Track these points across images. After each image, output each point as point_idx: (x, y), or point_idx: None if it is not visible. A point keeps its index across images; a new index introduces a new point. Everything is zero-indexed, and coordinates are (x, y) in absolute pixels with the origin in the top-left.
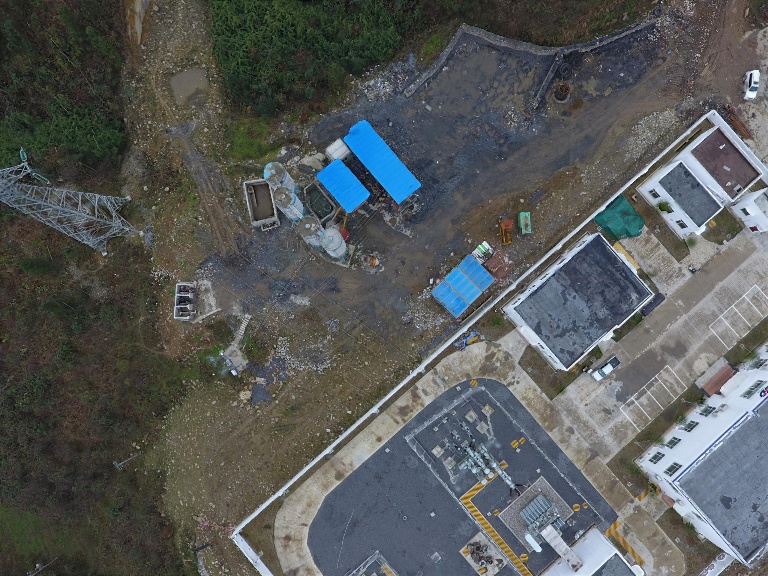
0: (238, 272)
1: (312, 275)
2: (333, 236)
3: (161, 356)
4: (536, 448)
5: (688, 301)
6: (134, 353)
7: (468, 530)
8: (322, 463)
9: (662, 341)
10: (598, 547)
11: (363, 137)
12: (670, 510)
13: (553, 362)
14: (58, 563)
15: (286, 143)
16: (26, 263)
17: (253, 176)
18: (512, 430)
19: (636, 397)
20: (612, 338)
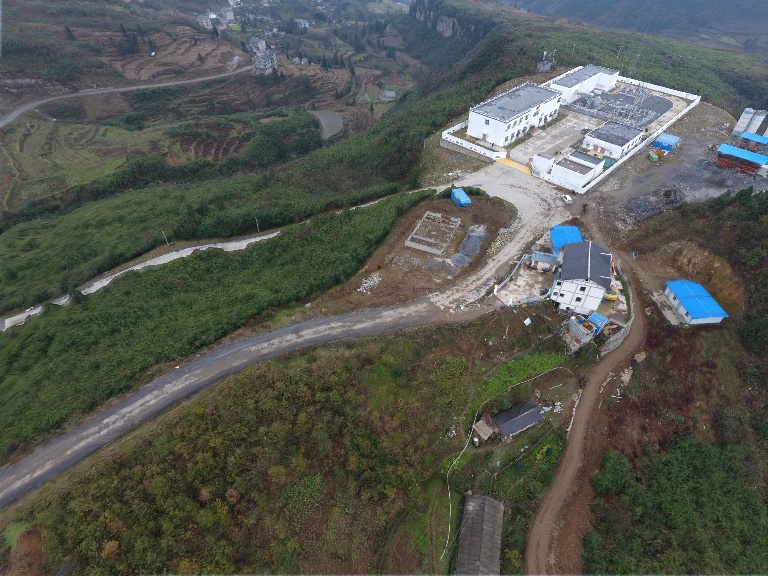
0: (766, 147)
1: None
2: (750, 110)
3: None
4: None
5: None
6: None
7: None
8: None
9: None
10: None
11: (759, 159)
12: None
13: None
14: None
15: None
16: None
17: None
18: None
19: None
20: None
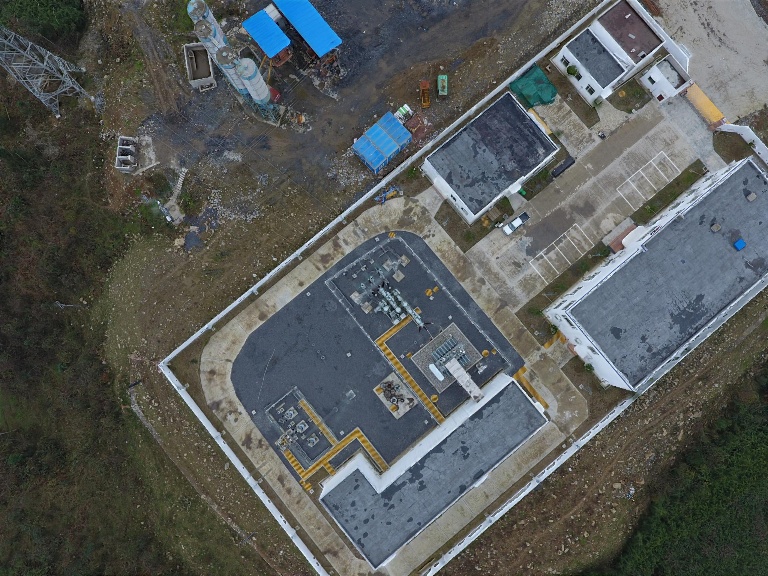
0: (177, 129)
1: (245, 133)
2: (247, 64)
3: (106, 210)
4: (448, 296)
5: (597, 165)
6: (80, 205)
7: (382, 371)
8: (247, 304)
9: (571, 201)
10: (500, 382)
11: None
12: (575, 358)
13: (466, 215)
14: (16, 435)
15: (226, 15)
16: None
17: None
18: (427, 279)
19: (545, 252)
20: (524, 197)
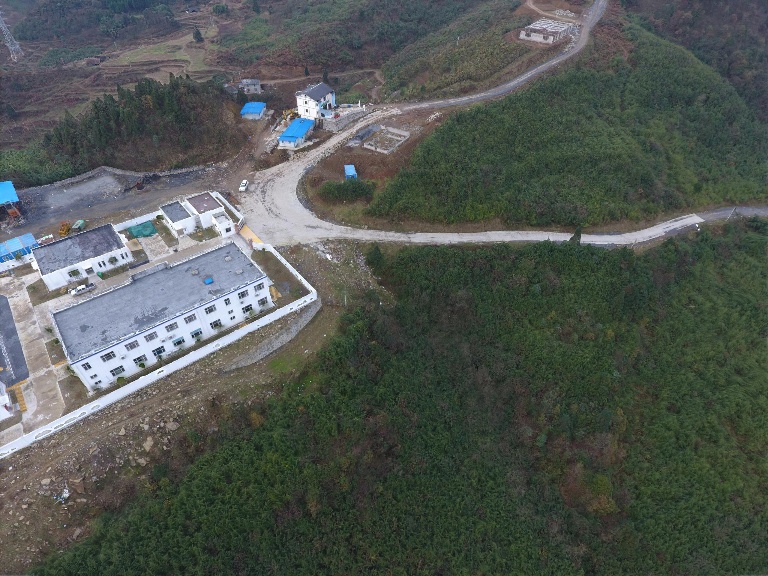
0: None
1: None
2: None
3: None
4: None
5: None
6: None
7: None
8: None
9: None
10: None
11: (3, 185)
12: None
13: None
14: None
15: None
16: None
17: None
18: None
19: None
20: (101, 278)
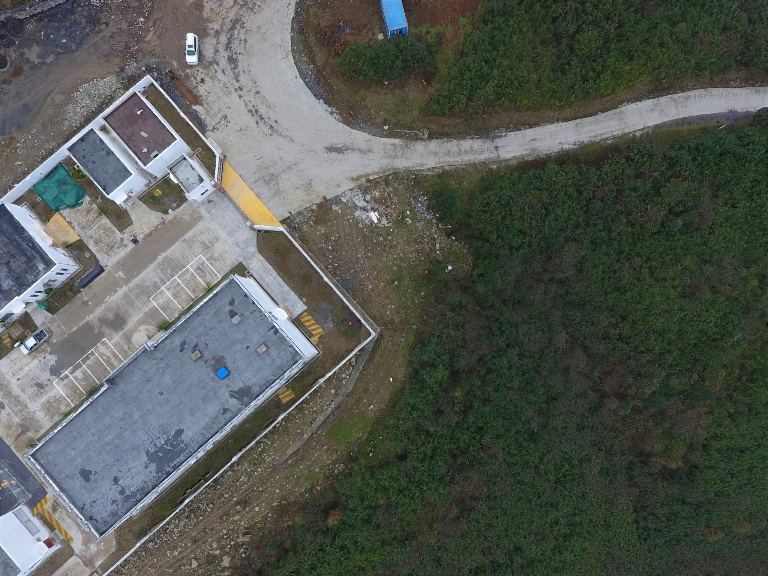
0: None
1: None
2: None
3: None
4: None
5: (129, 272)
6: None
7: None
8: None
9: (100, 314)
10: None
11: None
12: None
13: None
14: None
15: None
16: None
17: None
18: None
19: (71, 371)
20: (48, 311)
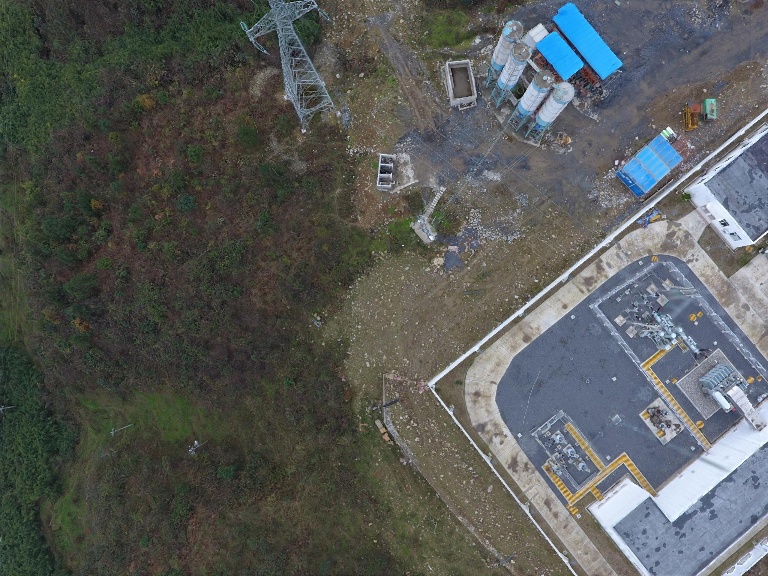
0: (435, 147)
1: (504, 153)
2: (567, 88)
3: (354, 227)
4: (713, 322)
5: None
6: (331, 222)
7: (647, 396)
8: (511, 326)
9: None
10: None
11: (570, 18)
12: None
13: (733, 241)
14: (208, 446)
15: (481, 32)
16: (245, 128)
17: (450, 60)
18: (690, 304)
19: None
20: None
